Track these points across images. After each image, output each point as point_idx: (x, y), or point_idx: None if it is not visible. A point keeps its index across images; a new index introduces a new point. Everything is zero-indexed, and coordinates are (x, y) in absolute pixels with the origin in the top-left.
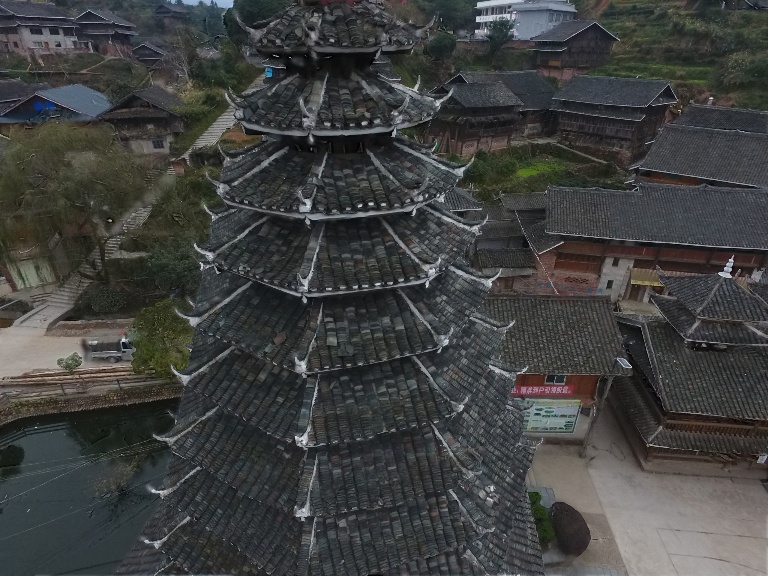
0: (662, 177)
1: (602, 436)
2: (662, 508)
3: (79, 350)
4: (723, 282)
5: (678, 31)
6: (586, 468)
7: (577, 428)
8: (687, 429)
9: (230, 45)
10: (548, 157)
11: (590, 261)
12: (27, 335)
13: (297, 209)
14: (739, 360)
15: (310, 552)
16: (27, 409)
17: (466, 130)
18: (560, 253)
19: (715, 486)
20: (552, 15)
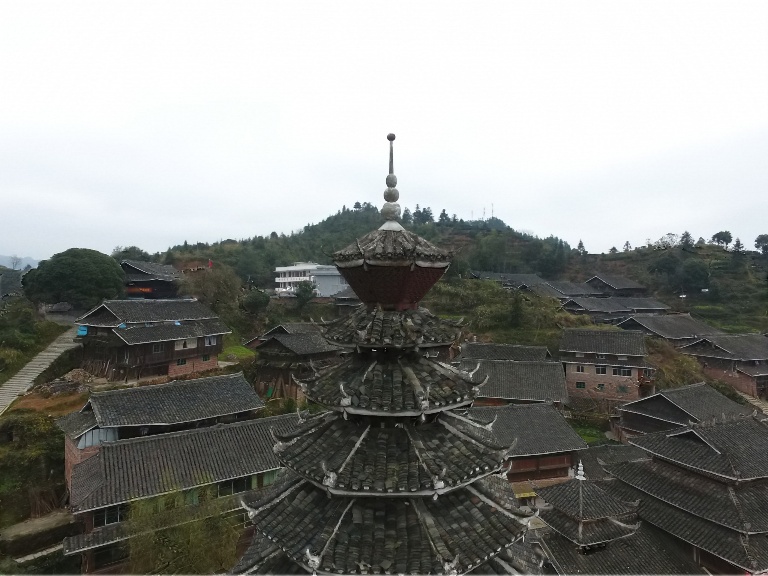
0: None
1: None
2: None
3: None
4: (582, 484)
5: (437, 292)
6: None
7: None
8: None
9: (22, 303)
10: None
11: None
12: None
13: (430, 486)
14: (618, 555)
15: None
16: None
17: (299, 374)
18: None
19: None
20: (342, 279)
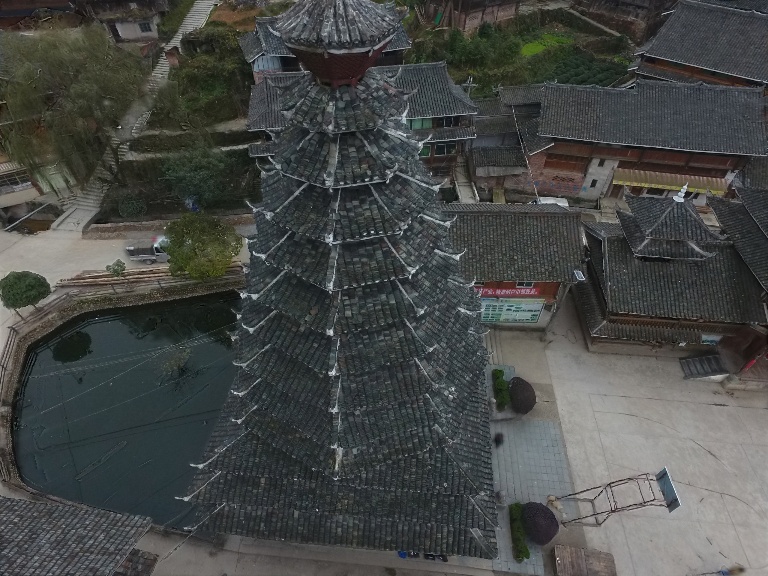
0: (666, 64)
1: (561, 324)
2: (597, 379)
3: (117, 252)
4: (675, 206)
5: None
6: (544, 350)
7: (541, 319)
8: (626, 323)
9: None
10: (558, 26)
11: (578, 161)
12: (67, 238)
13: (324, 239)
14: (678, 269)
15: (338, 429)
16: (88, 305)
17: (470, 0)
18: (550, 154)
19: (642, 363)
20: None
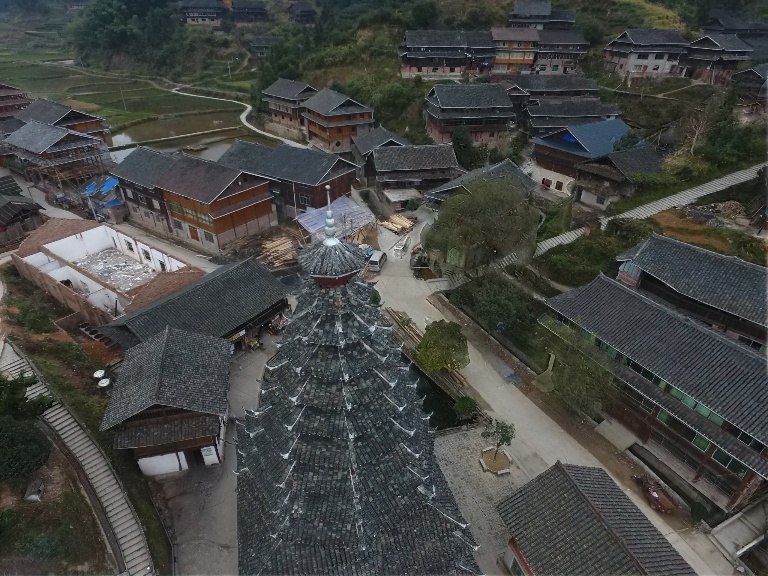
0: None
1: None
2: None
3: None
4: None
5: None
6: None
7: None
8: None
9: None
10: None
11: None
12: (423, 291)
13: None
14: None
15: (253, 451)
16: None
17: None
18: None
19: None
20: None
